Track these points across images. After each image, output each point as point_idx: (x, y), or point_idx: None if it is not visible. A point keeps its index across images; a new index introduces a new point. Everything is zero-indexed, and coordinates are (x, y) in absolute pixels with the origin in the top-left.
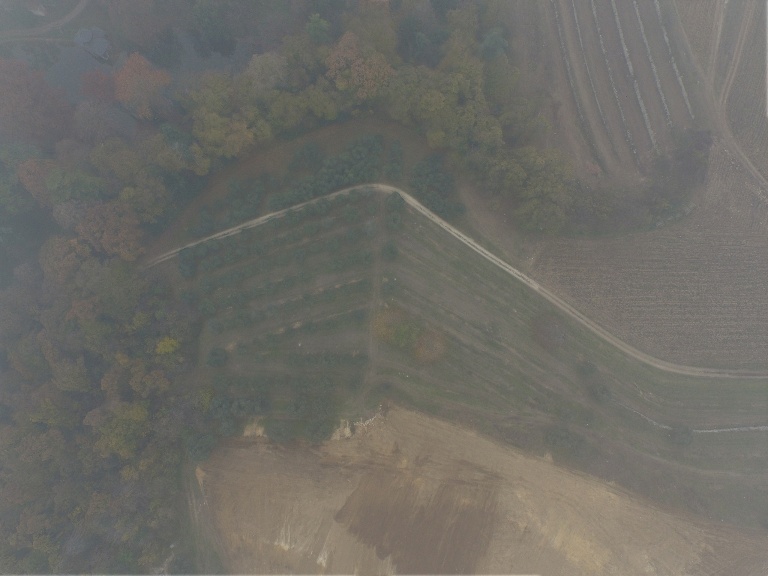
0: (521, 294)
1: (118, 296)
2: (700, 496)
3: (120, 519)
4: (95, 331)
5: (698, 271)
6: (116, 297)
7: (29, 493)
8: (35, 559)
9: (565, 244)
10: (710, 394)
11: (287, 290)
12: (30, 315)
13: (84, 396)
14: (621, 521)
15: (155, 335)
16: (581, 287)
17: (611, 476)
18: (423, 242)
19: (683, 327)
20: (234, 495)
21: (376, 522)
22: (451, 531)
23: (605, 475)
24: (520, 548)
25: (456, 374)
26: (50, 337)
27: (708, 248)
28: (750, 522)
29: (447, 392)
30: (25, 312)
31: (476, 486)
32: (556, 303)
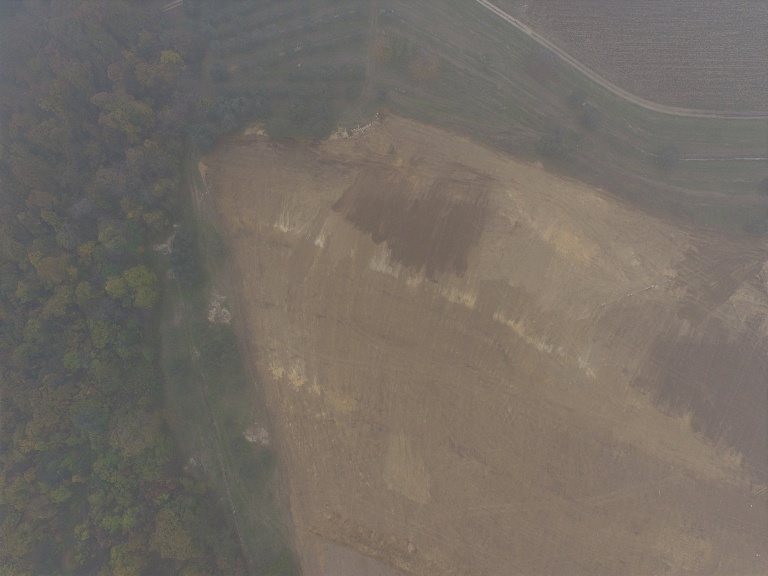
0: (514, 35)
1: (124, 11)
2: (686, 209)
3: (125, 196)
4: (102, 37)
5: (686, 19)
6: (122, 12)
7: (37, 177)
8: (43, 240)
9: None
10: (697, 131)
11: (287, 22)
12: (39, 23)
13: (90, 104)
14: (609, 222)
15: (159, 50)
16: (573, 32)
17: (600, 185)
18: None
19: (671, 70)
20: (235, 186)
21: (372, 212)
22: (444, 222)
23: (594, 184)
24: (511, 239)
25: (450, 92)
26: (58, 44)
27: None
28: (734, 228)
29: (442, 106)
30: (33, 39)
31: (469, 185)
32: (548, 47)
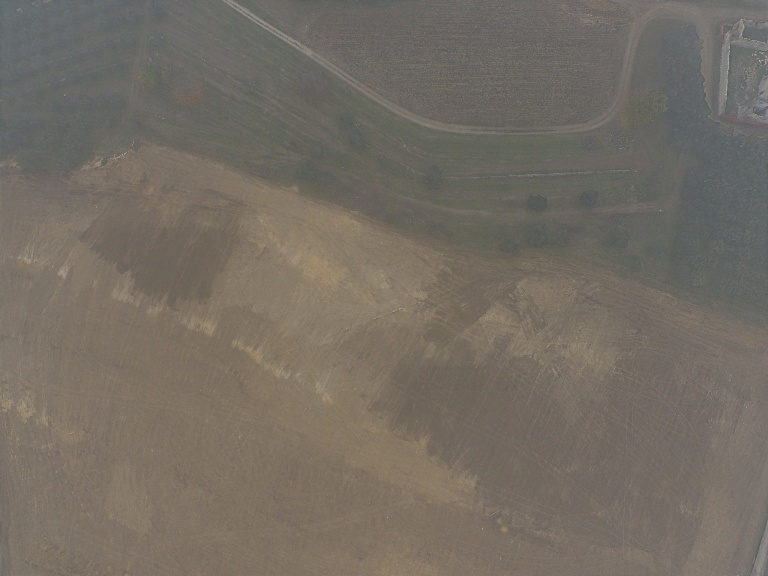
0: (292, 57)
1: None
2: (447, 229)
3: None
4: None
5: (467, 35)
6: None
7: None
8: None
9: (339, 13)
10: (475, 149)
11: (60, 52)
12: None
13: None
14: (362, 245)
15: None
16: (353, 52)
17: (357, 208)
18: (195, 8)
19: (451, 88)
20: None
21: (119, 242)
22: (191, 250)
23: (351, 206)
24: (258, 265)
25: (212, 118)
26: None
27: (478, 13)
28: (490, 248)
29: (201, 132)
30: None
31: (219, 211)
32: (328, 68)
